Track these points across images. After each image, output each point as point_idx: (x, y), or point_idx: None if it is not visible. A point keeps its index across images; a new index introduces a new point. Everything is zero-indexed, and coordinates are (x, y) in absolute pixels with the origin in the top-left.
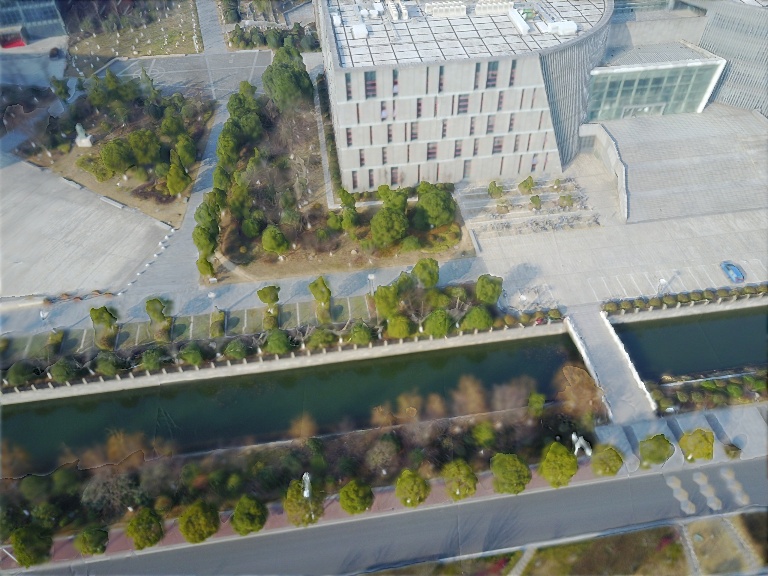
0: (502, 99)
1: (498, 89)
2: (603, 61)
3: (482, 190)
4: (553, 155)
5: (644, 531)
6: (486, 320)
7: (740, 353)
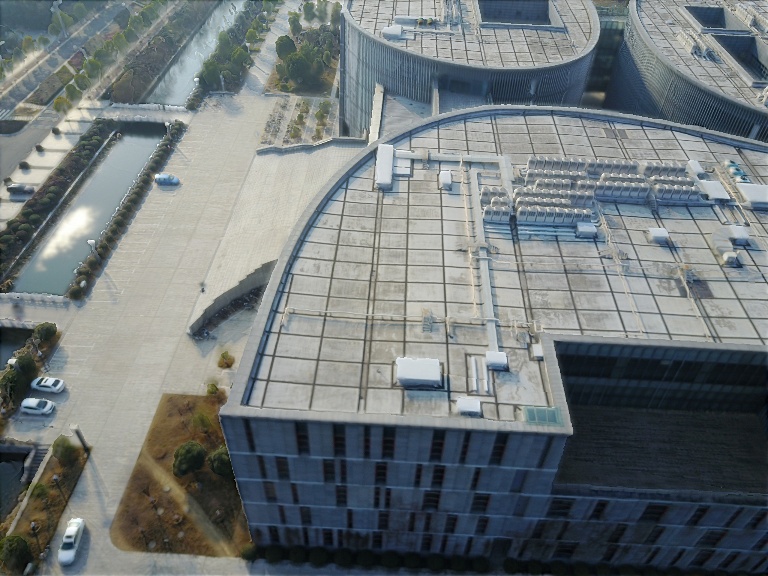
0: None
1: None
2: (400, 96)
3: (334, 109)
4: None
5: (51, 94)
6: (196, 75)
7: (114, 178)
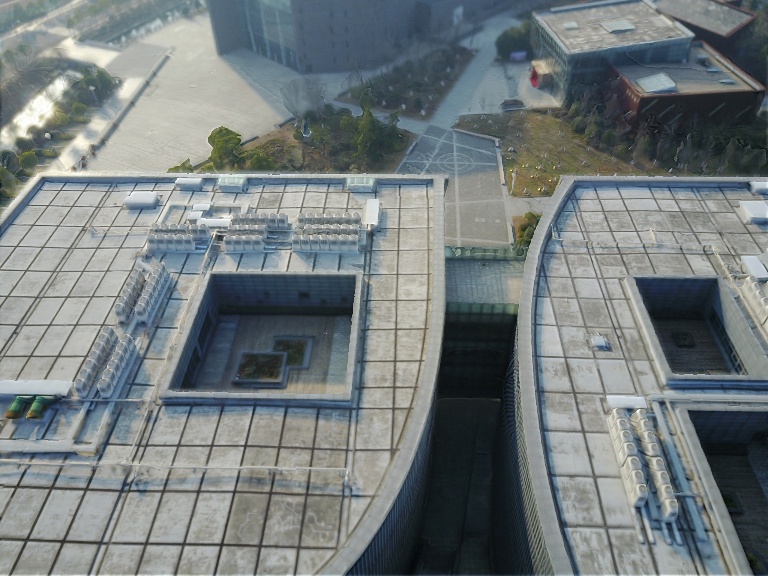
0: None
1: None
2: None
3: None
4: None
5: None
6: None
7: None
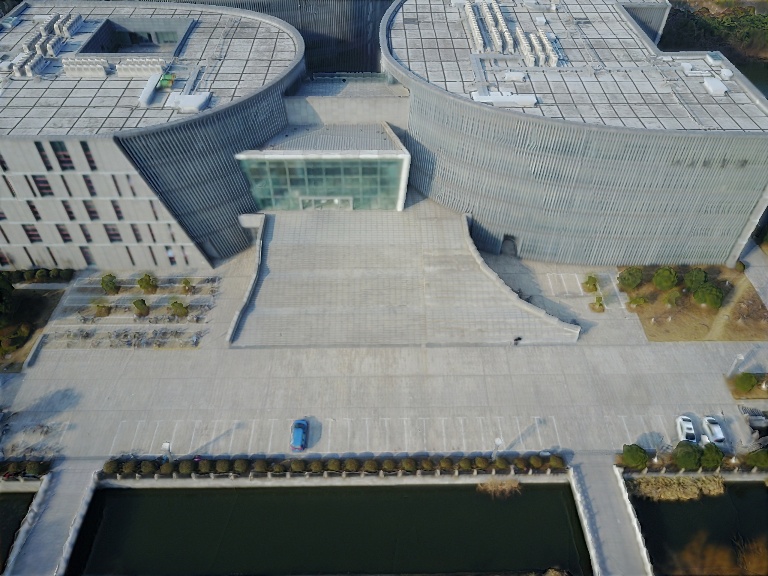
0: (92, 183)
1: (79, 172)
2: (268, 142)
3: None
4: (190, 249)
5: None
6: None
7: (247, 552)
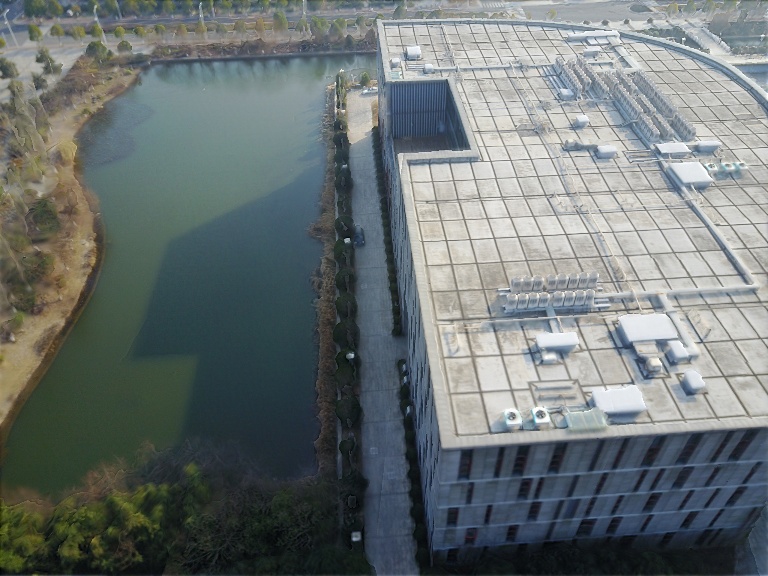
0: None
1: None
2: None
3: None
4: None
5: None
6: None
7: None
